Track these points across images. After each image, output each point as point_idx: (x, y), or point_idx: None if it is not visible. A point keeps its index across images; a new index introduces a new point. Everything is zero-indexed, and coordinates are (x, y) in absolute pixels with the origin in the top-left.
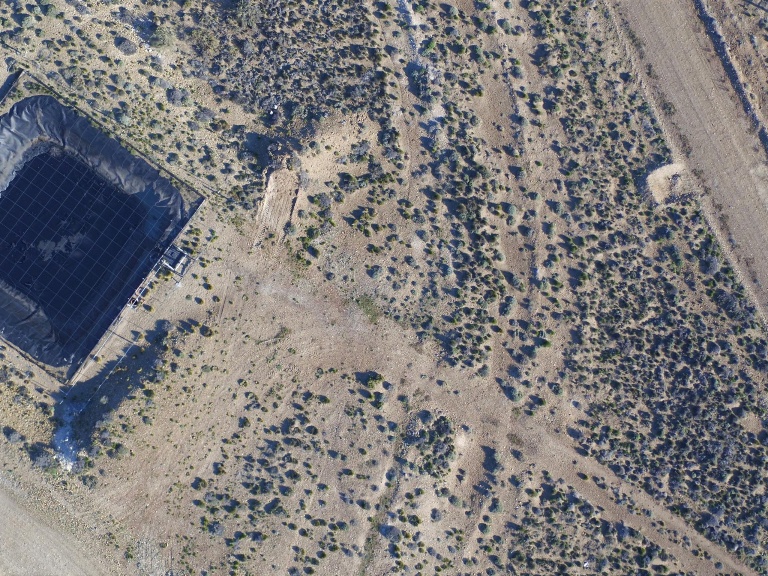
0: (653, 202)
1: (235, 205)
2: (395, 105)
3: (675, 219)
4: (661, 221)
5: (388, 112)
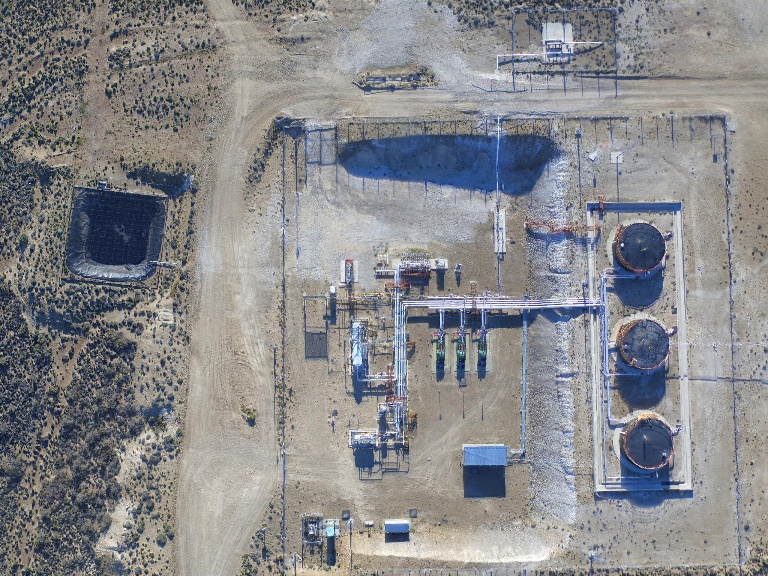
0: None
1: (71, 175)
2: (3, 141)
3: None
4: None
5: (7, 142)
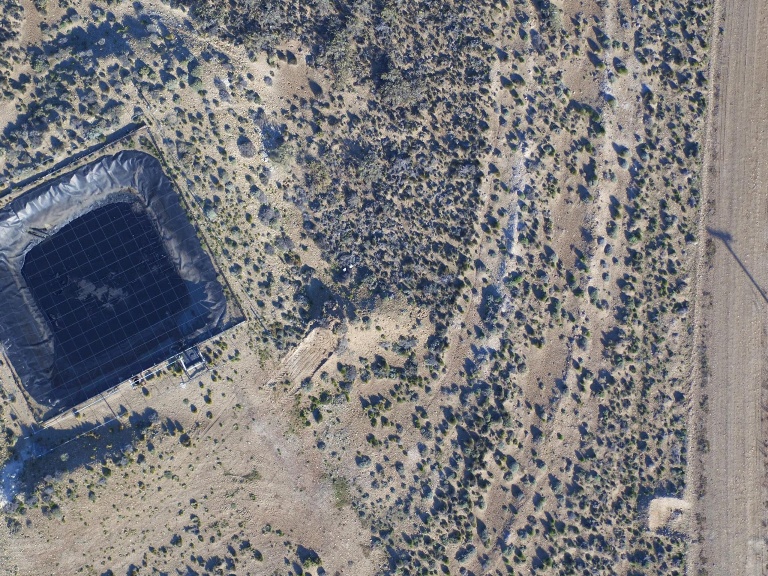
0: (646, 525)
1: (269, 339)
2: (458, 317)
3: (658, 551)
4: (644, 546)
5: (449, 320)
